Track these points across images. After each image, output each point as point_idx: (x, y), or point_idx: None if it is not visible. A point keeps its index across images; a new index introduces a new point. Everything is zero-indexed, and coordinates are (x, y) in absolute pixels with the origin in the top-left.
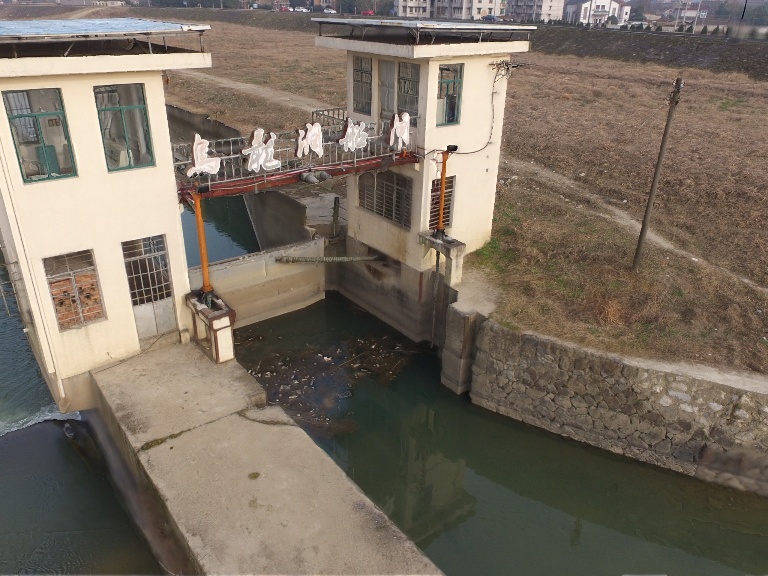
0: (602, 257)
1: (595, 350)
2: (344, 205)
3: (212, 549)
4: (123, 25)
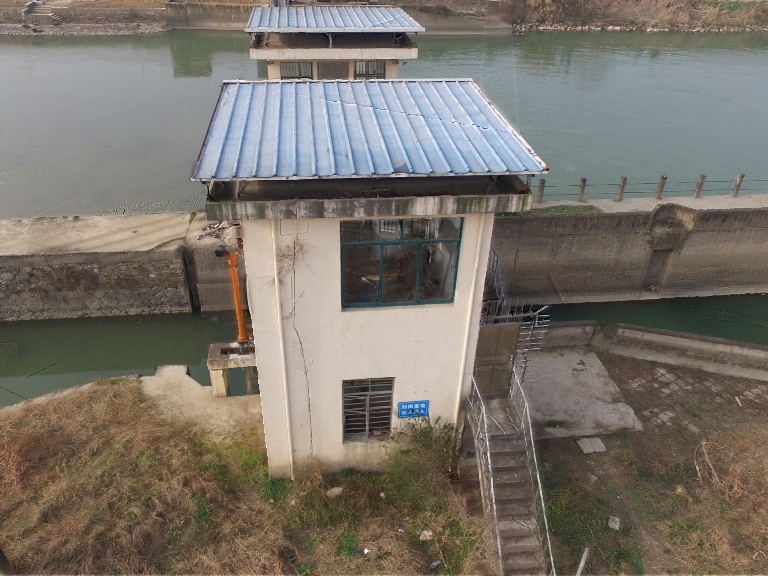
0: (73, 552)
1: (11, 410)
2: (555, 410)
3: (114, 217)
4: (305, 23)
